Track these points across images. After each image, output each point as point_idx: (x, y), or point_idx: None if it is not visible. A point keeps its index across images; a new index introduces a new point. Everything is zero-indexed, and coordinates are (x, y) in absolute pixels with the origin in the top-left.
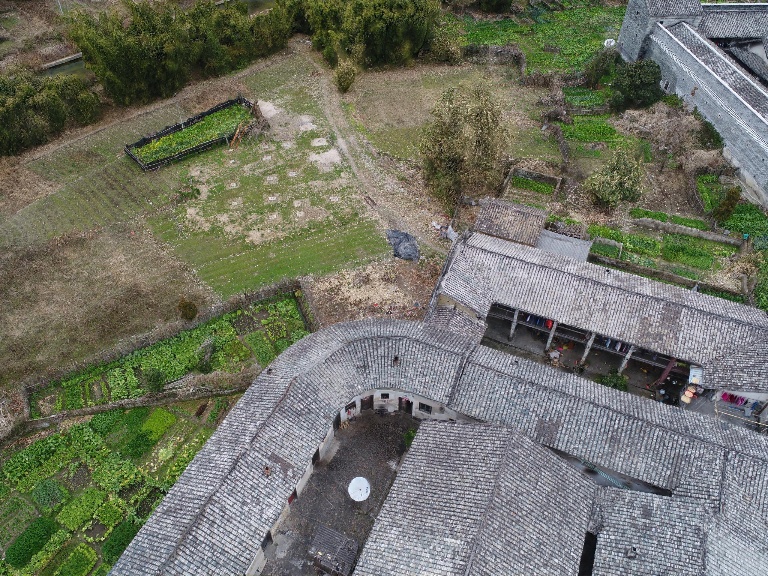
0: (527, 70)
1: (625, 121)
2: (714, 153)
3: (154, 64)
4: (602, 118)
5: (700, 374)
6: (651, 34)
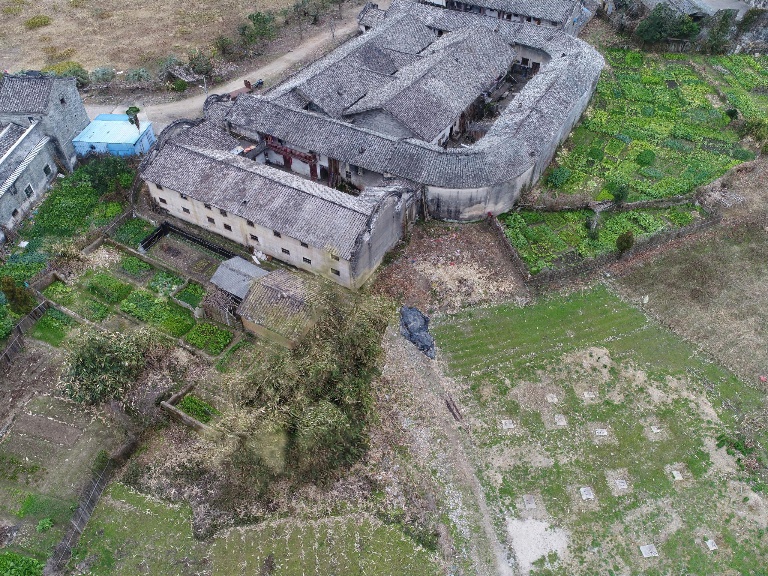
0: None
1: None
2: None
3: None
4: None
5: (233, 150)
6: None
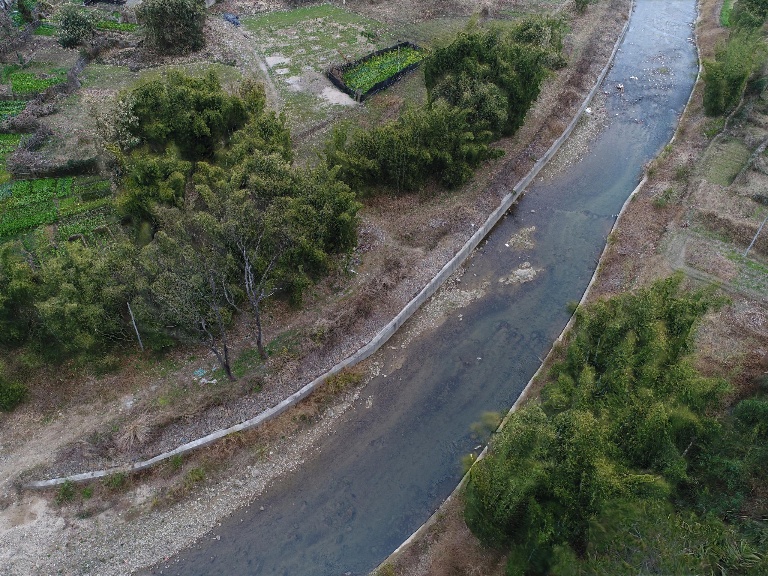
0: None
1: None
2: None
3: None
4: None
5: None
6: None
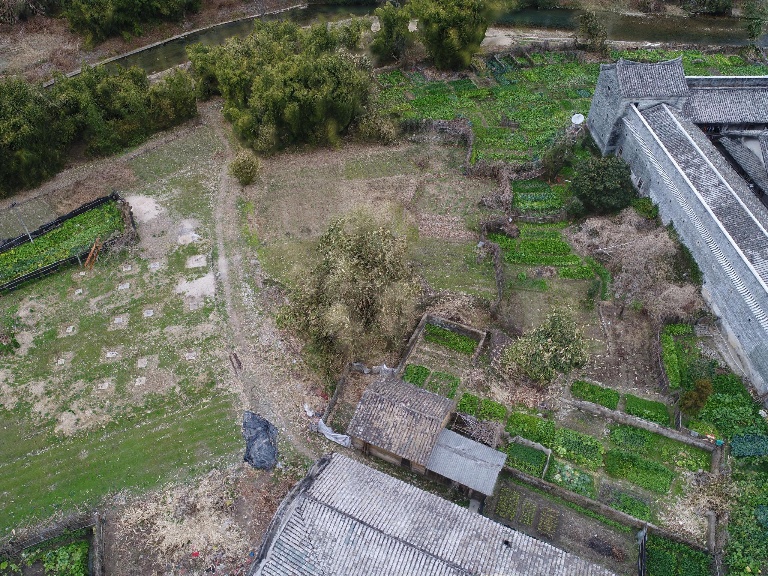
0: (475, 153)
1: (583, 235)
2: (690, 291)
3: (6, 154)
4: (556, 228)
5: None
6: (624, 116)
